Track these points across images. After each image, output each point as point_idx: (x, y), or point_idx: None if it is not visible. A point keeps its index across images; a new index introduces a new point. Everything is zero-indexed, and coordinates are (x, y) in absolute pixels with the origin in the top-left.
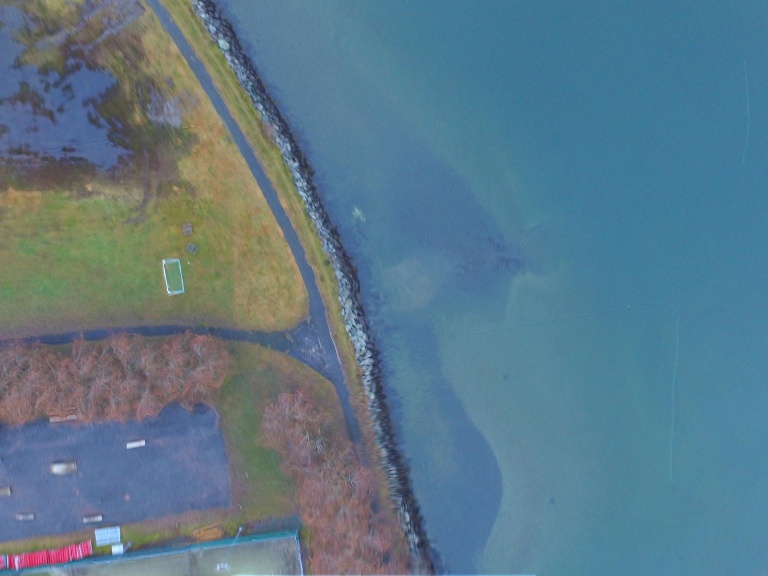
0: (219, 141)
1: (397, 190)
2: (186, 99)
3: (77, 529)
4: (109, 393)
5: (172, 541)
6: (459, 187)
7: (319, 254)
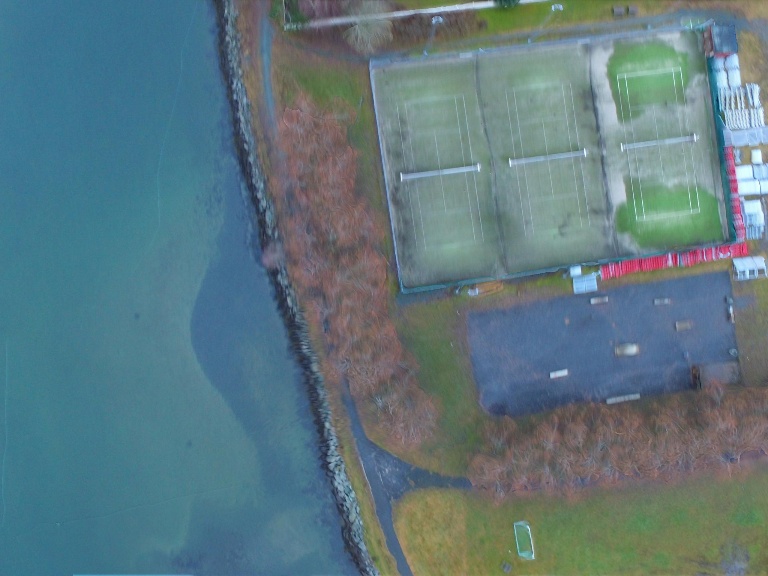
0: None
1: None
2: None
3: (615, 290)
4: None
5: (524, 279)
6: None
7: (383, 567)
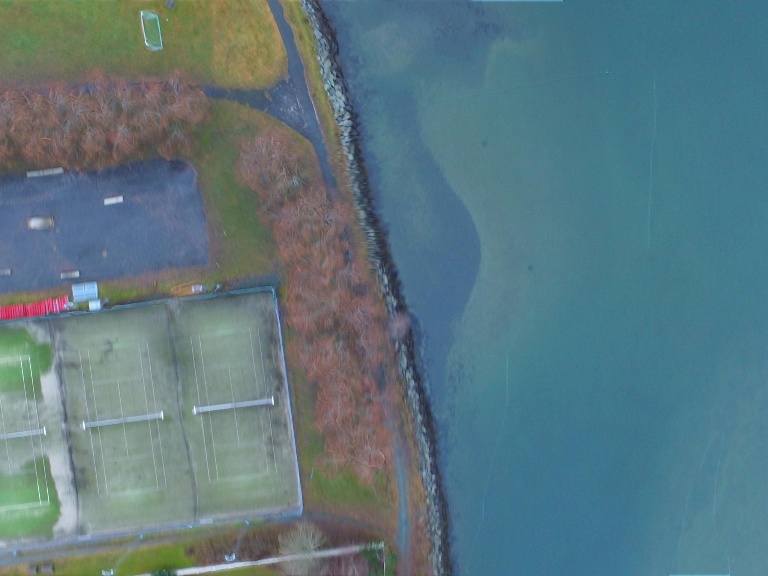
0: None
1: None
2: None
3: (54, 285)
4: None
5: (149, 298)
6: None
7: (298, 12)
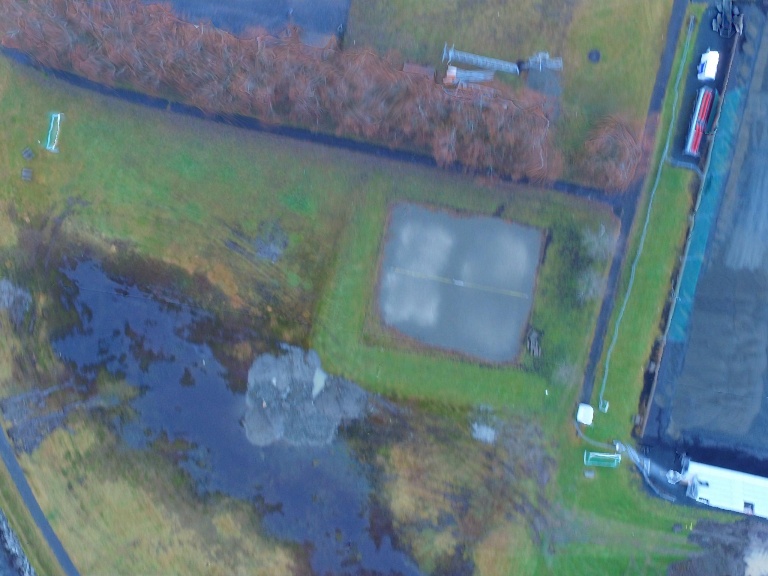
0: None
1: None
2: None
3: None
4: None
5: None
6: None
7: None
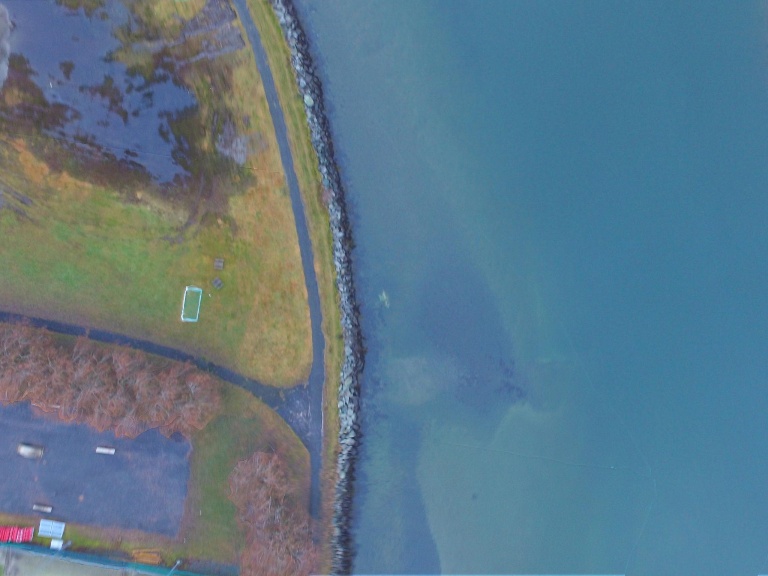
0: (275, 190)
1: (428, 287)
2: (257, 141)
3: (25, 513)
4: (96, 401)
5: (110, 553)
6: (488, 303)
7: (335, 326)
